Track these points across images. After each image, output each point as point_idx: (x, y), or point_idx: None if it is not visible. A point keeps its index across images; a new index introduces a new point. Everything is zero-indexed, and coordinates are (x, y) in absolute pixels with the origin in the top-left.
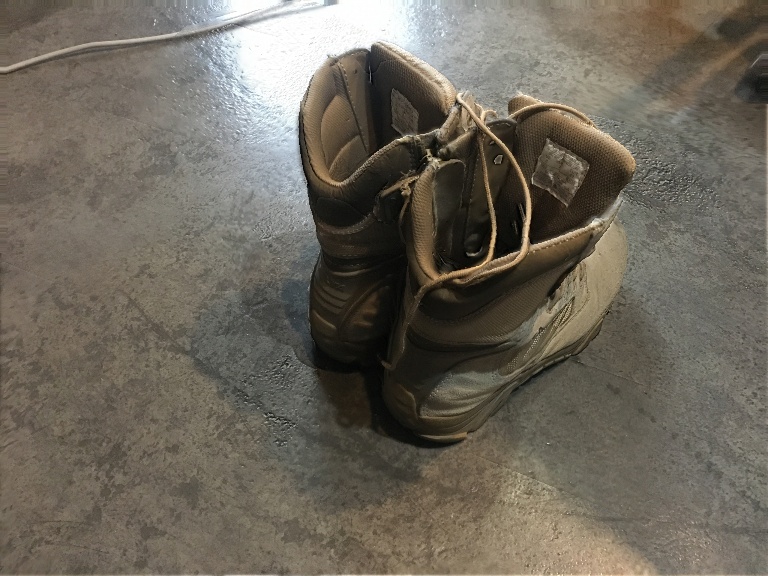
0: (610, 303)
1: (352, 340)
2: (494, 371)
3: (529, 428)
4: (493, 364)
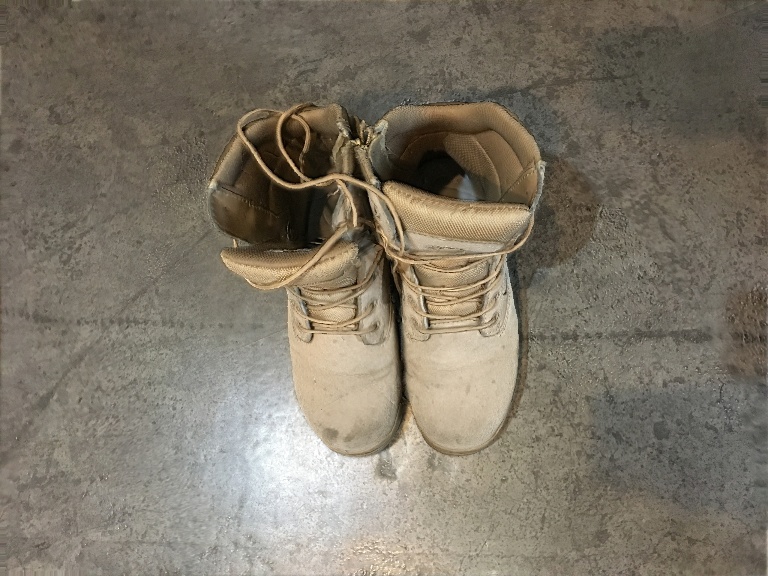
0: None
1: None
2: None
3: None
4: None
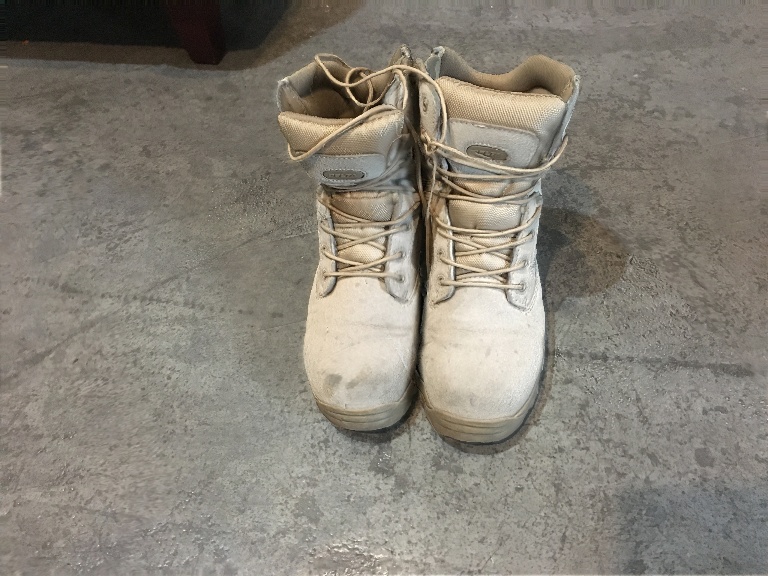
0: None
1: None
2: None
3: None
4: None
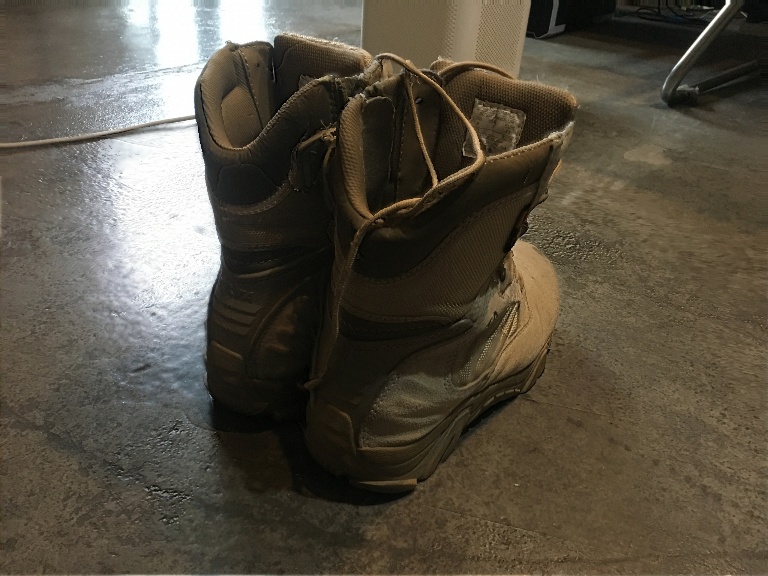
0: (551, 333)
1: (263, 375)
2: (446, 377)
3: (490, 470)
4: (444, 367)
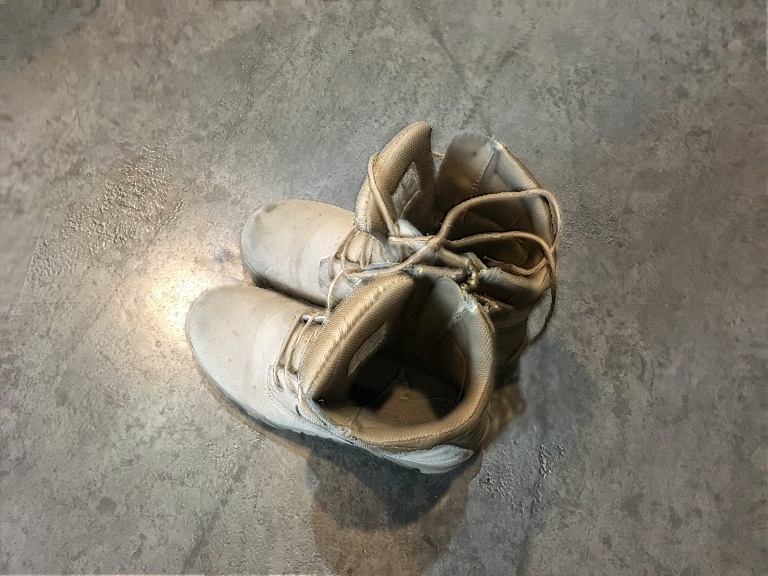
0: None
1: None
2: None
3: None
4: None
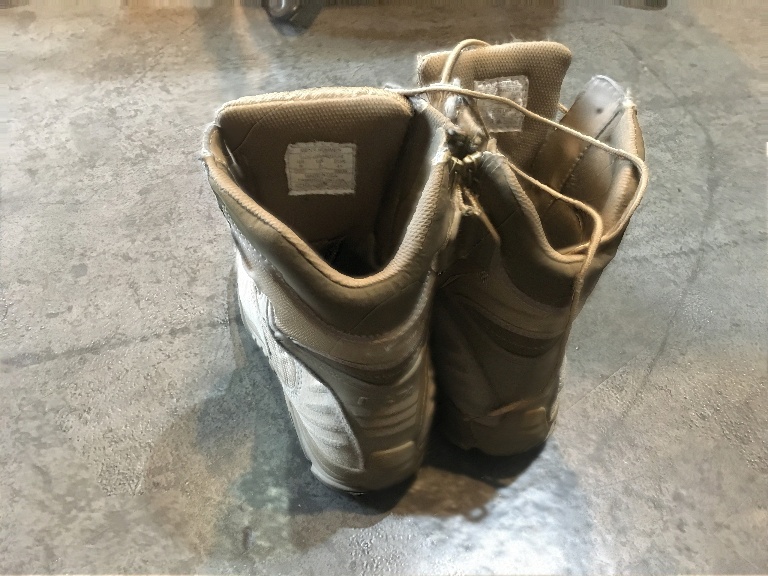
0: None
1: (423, 438)
2: None
3: None
4: None
